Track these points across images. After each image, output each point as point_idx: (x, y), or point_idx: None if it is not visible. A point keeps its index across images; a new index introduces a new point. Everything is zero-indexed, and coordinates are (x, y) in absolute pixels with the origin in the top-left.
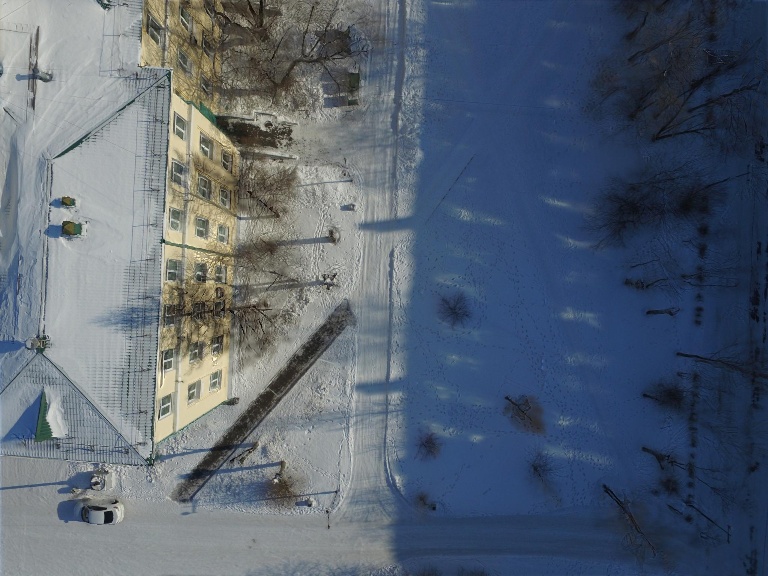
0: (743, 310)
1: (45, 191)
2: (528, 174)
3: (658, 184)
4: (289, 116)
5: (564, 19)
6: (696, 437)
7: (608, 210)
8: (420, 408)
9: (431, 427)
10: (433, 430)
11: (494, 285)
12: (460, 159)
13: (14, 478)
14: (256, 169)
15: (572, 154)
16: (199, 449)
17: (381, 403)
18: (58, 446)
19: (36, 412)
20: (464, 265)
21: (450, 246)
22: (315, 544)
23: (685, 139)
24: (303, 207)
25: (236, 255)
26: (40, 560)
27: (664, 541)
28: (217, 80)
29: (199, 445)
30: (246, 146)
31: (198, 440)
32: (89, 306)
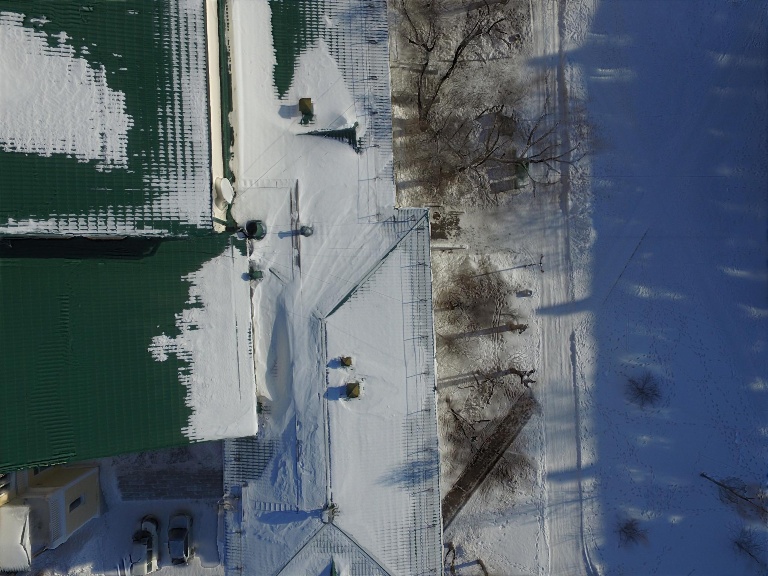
0: None
1: (320, 352)
2: (705, 245)
3: None
4: (455, 205)
5: (728, 84)
6: None
7: None
8: (615, 493)
9: (629, 512)
10: (632, 515)
11: (680, 361)
12: (633, 235)
13: None
14: None
15: (748, 221)
16: None
17: (574, 491)
18: None
19: None
20: (647, 343)
21: (631, 324)
22: None
23: None
24: (478, 297)
25: None
26: None
27: None
28: None
29: None
30: None
31: None
32: (372, 467)
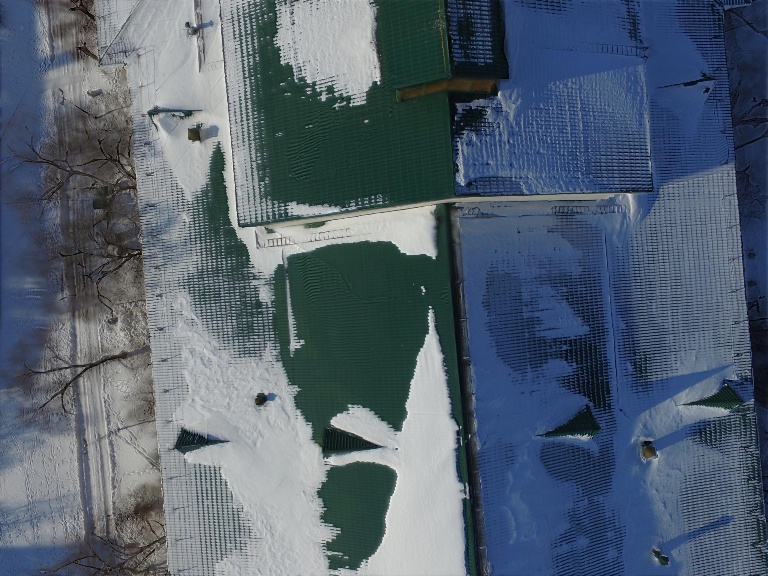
0: None
1: None
2: None
3: None
4: None
5: None
6: None
7: None
8: None
9: None
10: None
11: None
12: (4, 152)
13: None
14: None
15: None
16: None
17: None
18: None
19: None
20: None
21: (3, 72)
22: None
23: None
24: None
25: None
26: None
27: None
28: None
29: None
30: None
31: None
32: None
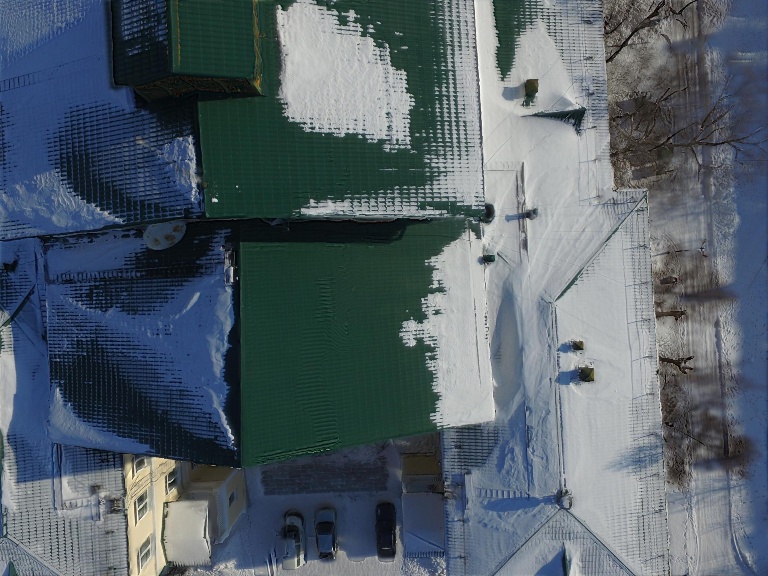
0: None
1: (551, 336)
2: None
3: None
4: None
5: None
6: None
7: None
8: (764, 480)
9: None
10: None
11: None
12: None
13: None
14: None
15: None
16: None
17: (721, 479)
18: None
19: (557, 570)
20: None
21: None
22: None
23: None
24: None
25: None
26: None
27: None
28: None
29: None
30: None
31: None
32: (602, 452)
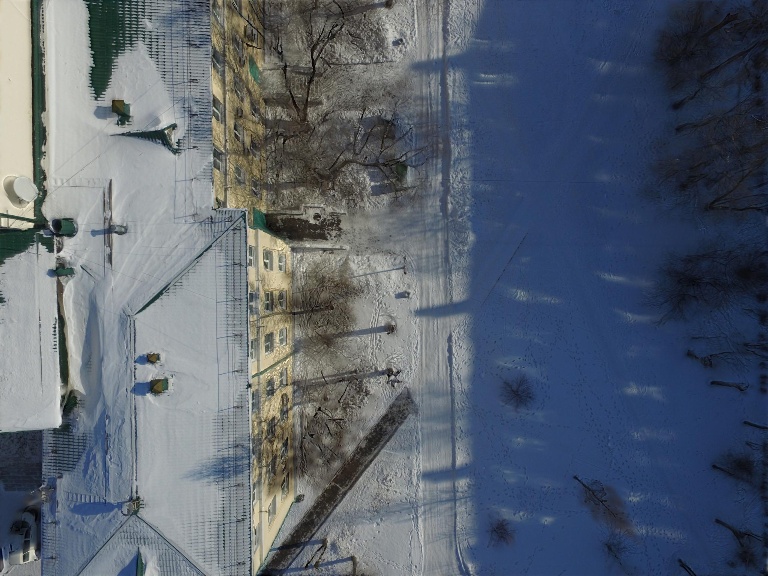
0: None
1: (129, 348)
2: (582, 250)
3: (719, 260)
4: (337, 206)
5: (608, 92)
6: None
7: (669, 287)
8: (488, 493)
9: (501, 512)
10: (504, 516)
11: (555, 364)
12: (512, 239)
13: None
14: (307, 262)
15: (625, 227)
16: None
17: (448, 490)
18: None
19: (133, 573)
20: (524, 346)
21: (508, 327)
22: None
23: (746, 216)
24: (357, 298)
25: (293, 351)
26: None
27: None
28: (263, 177)
29: None
30: (297, 241)
31: None
32: (180, 461)
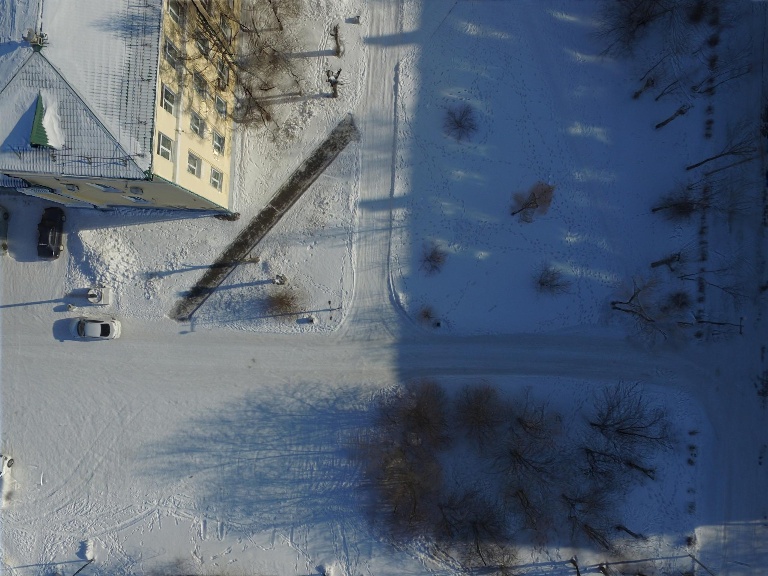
0: (754, 126)
1: None
2: None
3: None
4: None
5: None
6: (706, 251)
7: (617, 12)
8: (425, 224)
9: (436, 242)
10: (438, 244)
11: (501, 99)
12: None
13: (9, 296)
14: None
15: None
16: (198, 266)
17: (385, 219)
18: (54, 158)
19: (32, 116)
20: (470, 79)
21: (456, 60)
22: (316, 364)
23: None
24: (307, 19)
25: (238, 65)
26: (34, 380)
27: (673, 361)
28: None
29: (199, 261)
30: None
31: (198, 256)
32: (88, 8)
